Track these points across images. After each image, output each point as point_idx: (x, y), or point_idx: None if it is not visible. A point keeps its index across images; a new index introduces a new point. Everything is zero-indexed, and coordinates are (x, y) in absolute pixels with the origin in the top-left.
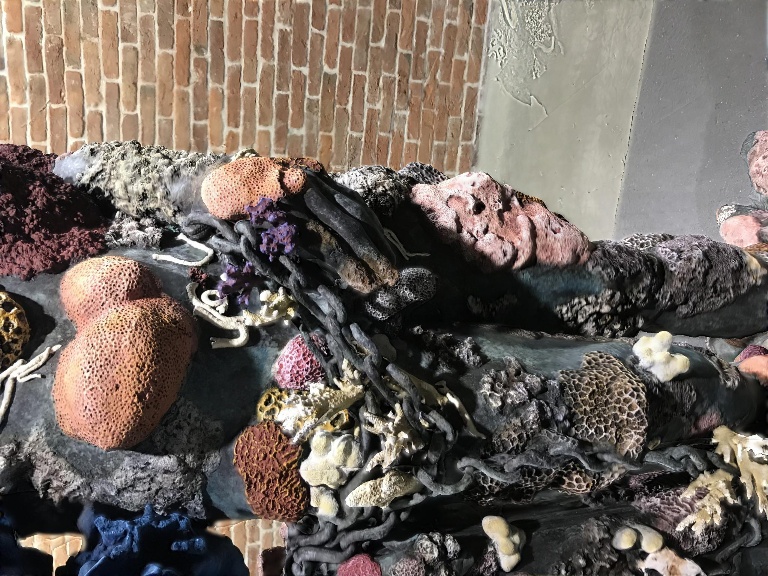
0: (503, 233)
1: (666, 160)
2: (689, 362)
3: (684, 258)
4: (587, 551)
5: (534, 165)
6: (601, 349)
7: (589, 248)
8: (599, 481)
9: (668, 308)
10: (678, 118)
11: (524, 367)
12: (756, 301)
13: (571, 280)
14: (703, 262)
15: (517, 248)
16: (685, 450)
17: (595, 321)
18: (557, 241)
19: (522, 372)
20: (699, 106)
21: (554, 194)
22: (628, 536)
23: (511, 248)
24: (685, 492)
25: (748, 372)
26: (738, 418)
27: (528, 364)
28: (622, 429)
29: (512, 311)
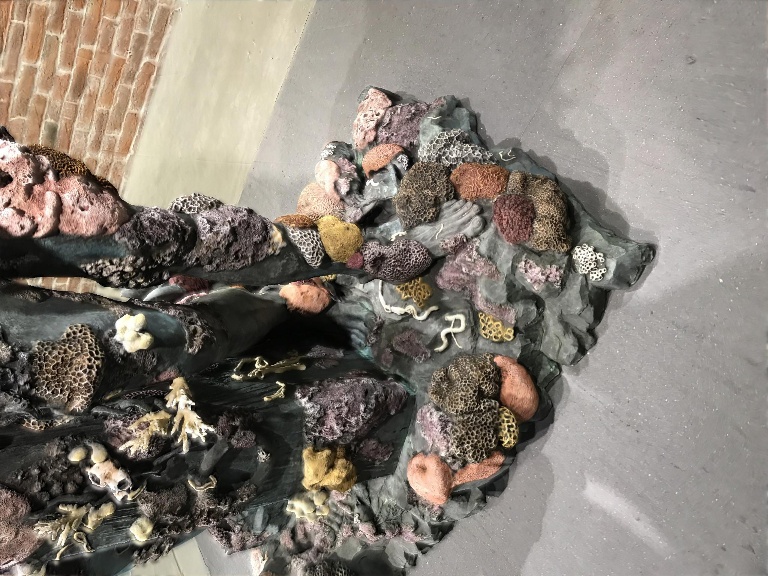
0: (26, 207)
1: (321, 69)
2: (149, 343)
3: (214, 231)
4: (45, 462)
5: (236, 4)
6: (88, 321)
7: (119, 222)
8: (53, 423)
9: (195, 266)
10: (338, 35)
11: (7, 335)
12: (271, 267)
13: (96, 247)
14: (228, 237)
15: (37, 223)
16: (130, 403)
17: (120, 276)
18: (83, 218)
19: (1, 342)
20: (354, 33)
21: (246, 45)
22: (78, 454)
23: (29, 224)
24: (131, 425)
25: (283, 297)
26: (195, 372)
27: (13, 332)
28: (75, 392)
29: (35, 265)
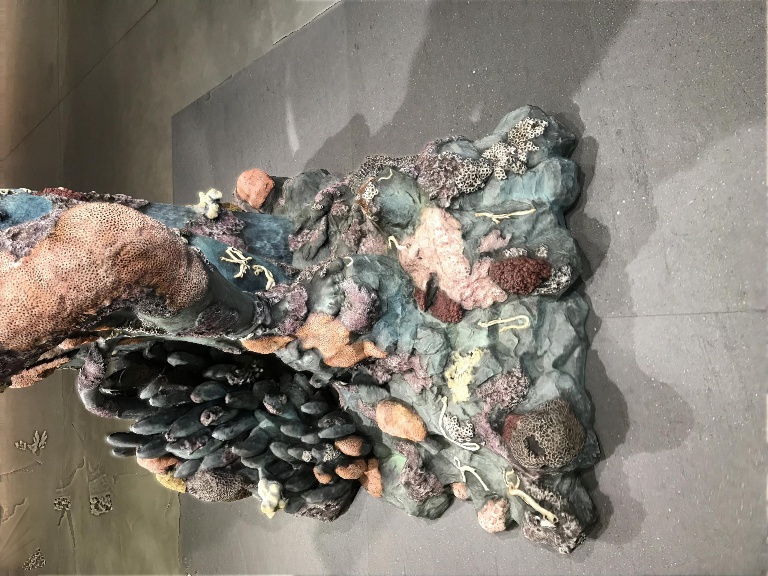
0: None
1: (263, 566)
2: None
3: None
4: None
5: None
6: None
7: None
8: None
9: None
10: (246, 553)
11: None
12: None
13: None
14: None
15: None
16: None
17: None
18: None
19: None
20: (241, 532)
21: None
22: None
23: None
24: None
25: None
26: None
27: None
28: None
29: None
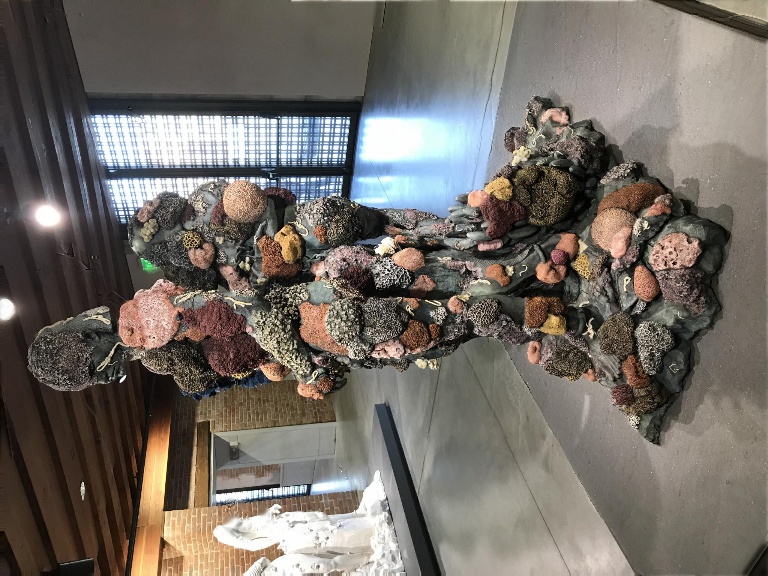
0: None
1: (759, 109)
2: None
3: None
4: None
5: None
6: None
7: None
8: None
9: None
10: None
11: None
12: None
13: None
14: None
15: None
16: None
17: None
18: None
19: (379, 362)
20: None
21: None
22: None
23: None
24: None
25: (536, 271)
26: None
27: None
28: None
29: None
